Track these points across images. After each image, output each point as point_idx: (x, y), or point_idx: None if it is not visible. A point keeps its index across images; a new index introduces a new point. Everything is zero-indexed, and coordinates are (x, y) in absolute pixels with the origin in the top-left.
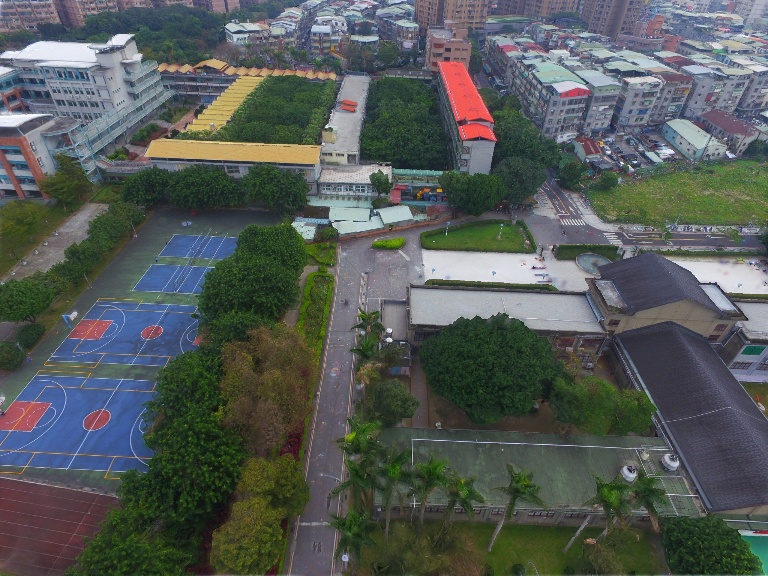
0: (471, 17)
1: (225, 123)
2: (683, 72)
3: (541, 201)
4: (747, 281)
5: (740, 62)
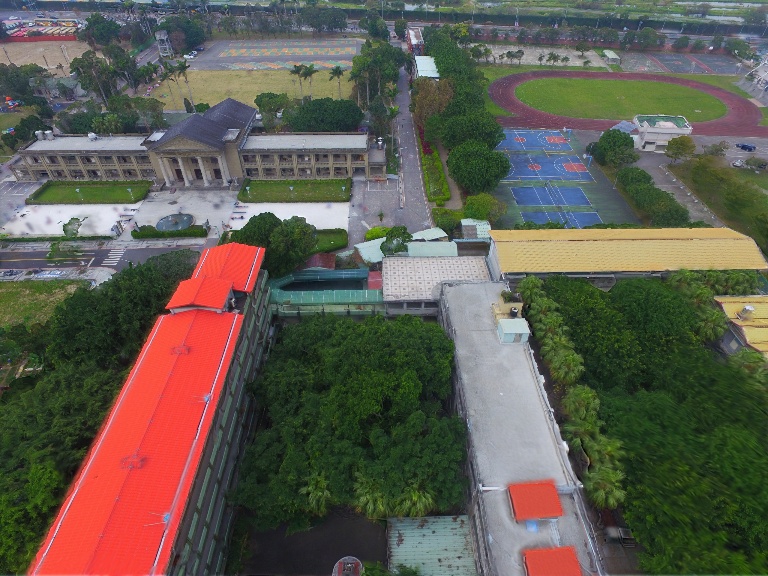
0: None
1: (756, 345)
2: None
3: None
4: (38, 218)
5: None
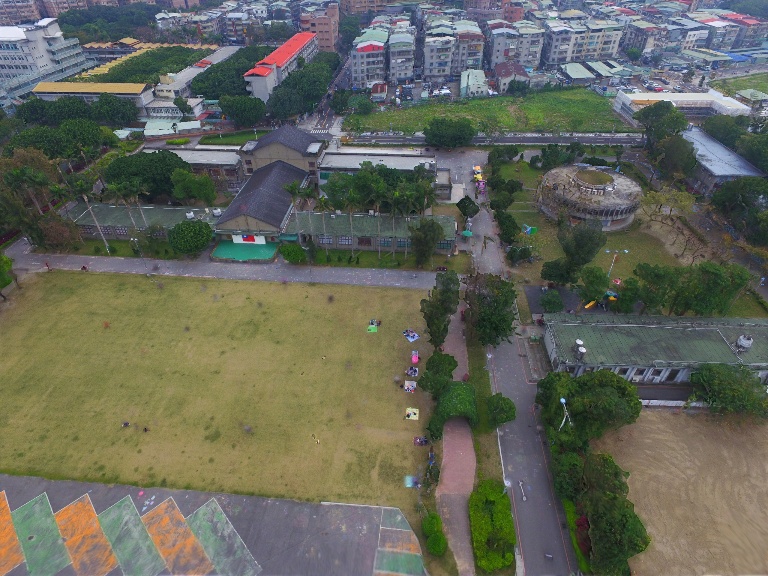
0: (372, 1)
1: None
2: (491, 34)
3: (310, 121)
4: None
5: (550, 25)
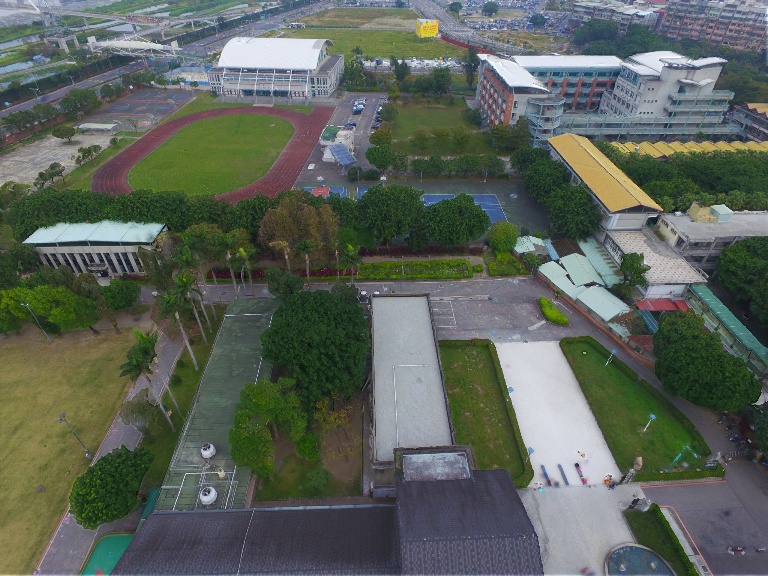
0: None
1: (658, 156)
2: None
3: None
4: None
5: None
